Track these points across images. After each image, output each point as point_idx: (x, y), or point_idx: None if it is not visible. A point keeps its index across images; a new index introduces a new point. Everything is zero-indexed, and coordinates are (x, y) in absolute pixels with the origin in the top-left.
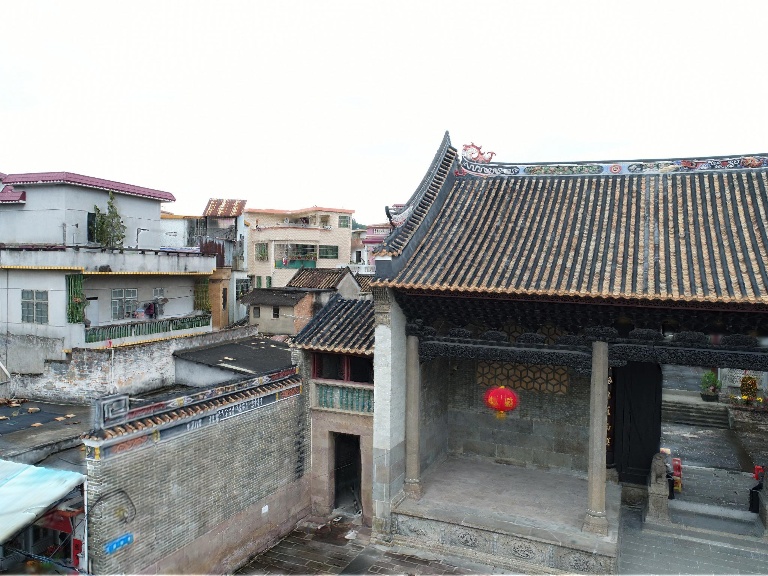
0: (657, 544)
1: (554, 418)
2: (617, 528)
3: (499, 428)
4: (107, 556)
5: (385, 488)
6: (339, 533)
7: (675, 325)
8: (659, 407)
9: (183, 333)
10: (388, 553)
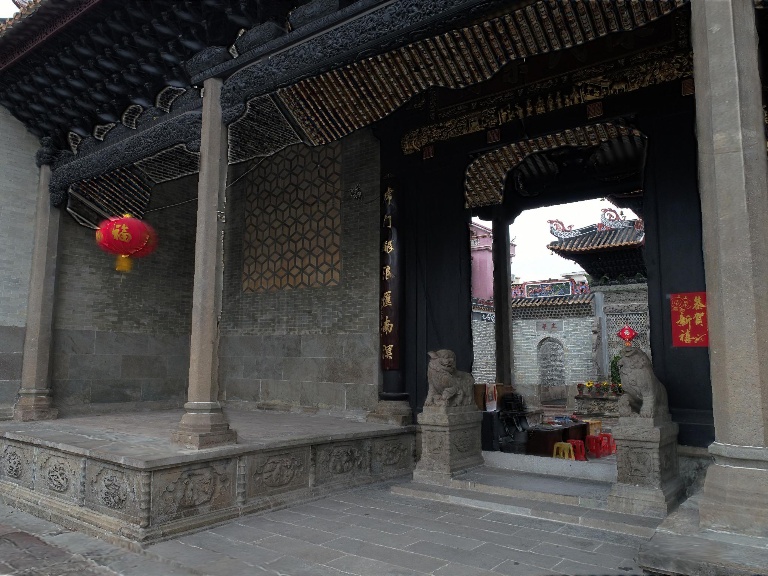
0: (384, 505)
1: (325, 326)
2: None
3: (264, 354)
4: None
5: None
6: None
7: (298, 3)
8: (465, 282)
9: None
10: None
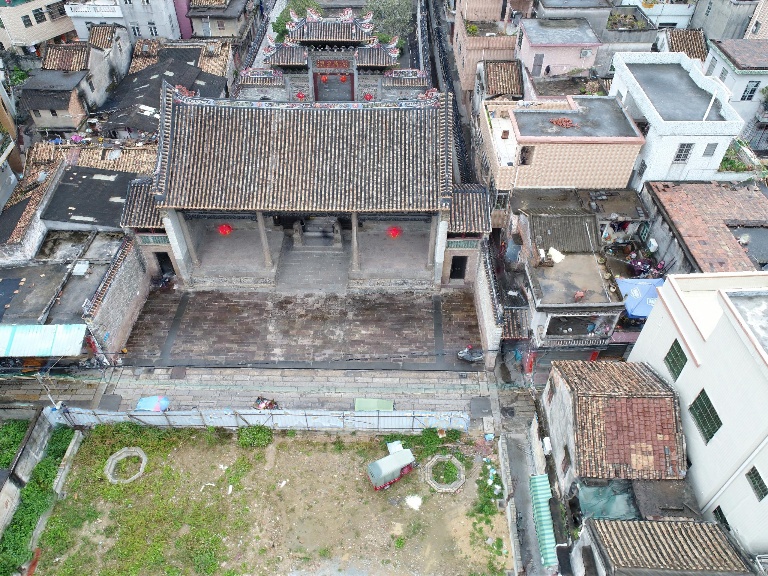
0: (296, 258)
1: None
2: (277, 263)
3: None
4: (105, 342)
5: (185, 271)
6: (170, 287)
7: None
8: None
9: (1, 161)
10: (193, 292)
